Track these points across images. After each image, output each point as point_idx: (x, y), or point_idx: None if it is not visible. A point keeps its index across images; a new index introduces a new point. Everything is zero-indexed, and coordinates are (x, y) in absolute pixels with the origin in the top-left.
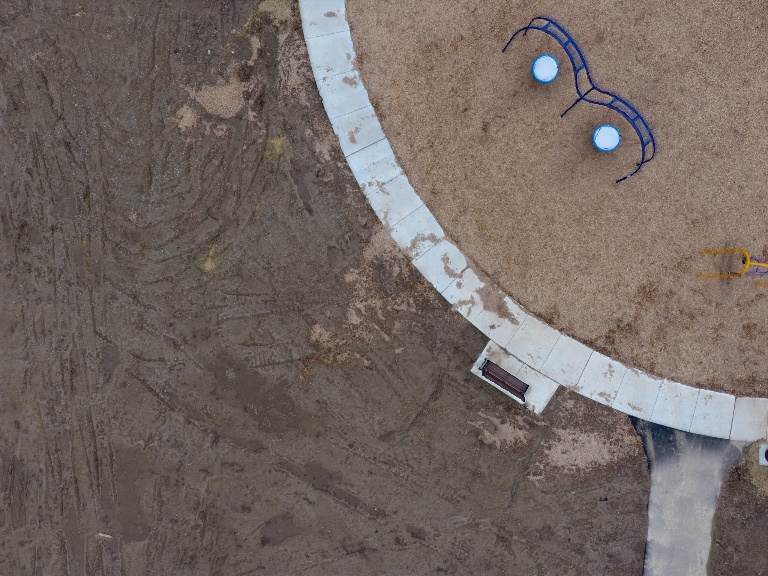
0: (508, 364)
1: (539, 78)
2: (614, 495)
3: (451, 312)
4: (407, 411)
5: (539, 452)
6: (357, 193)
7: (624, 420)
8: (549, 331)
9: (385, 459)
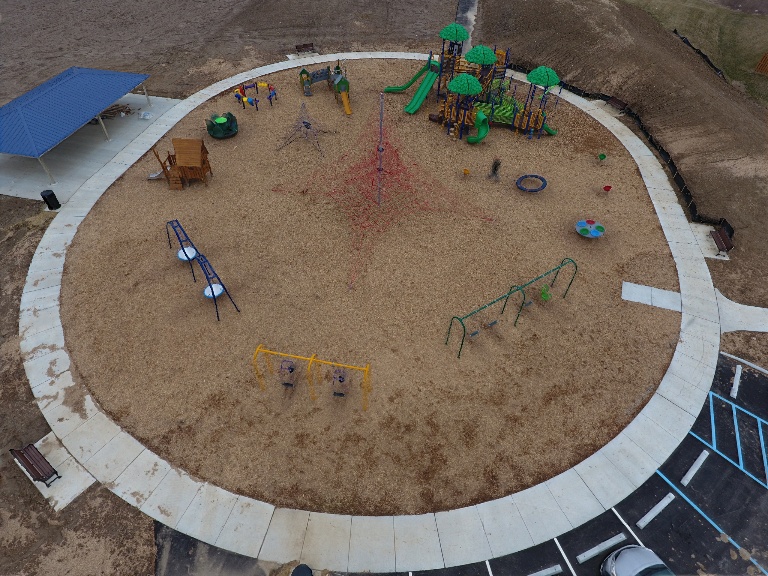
0: (55, 455)
1: (181, 257)
2: None
3: (30, 404)
4: None
5: (32, 557)
6: (14, 315)
7: (147, 525)
8: (112, 427)
9: None
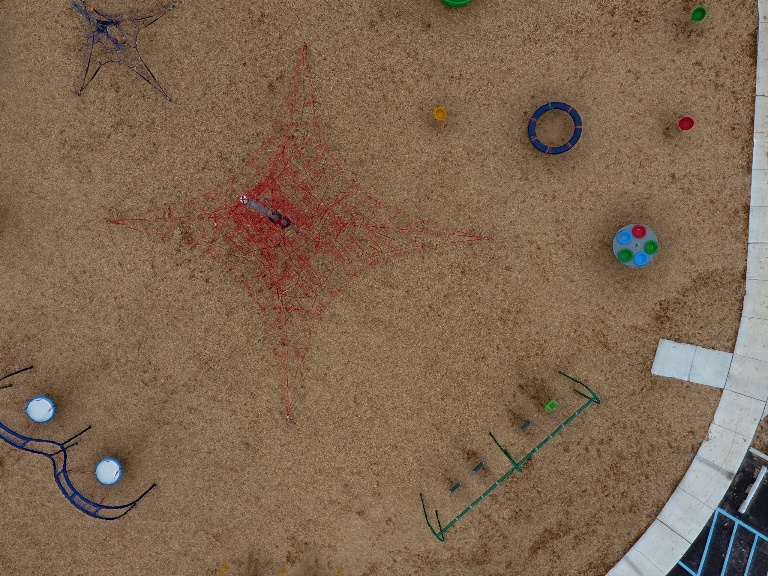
0: None
1: (35, 419)
2: None
3: None
4: None
5: None
6: None
7: None
8: None
9: None
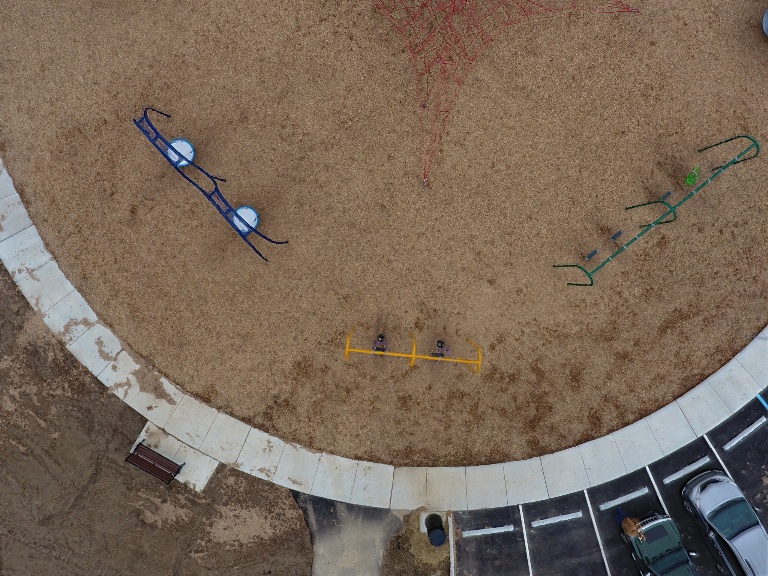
0: (167, 444)
1: None
2: (277, 568)
3: (107, 395)
4: (66, 495)
5: (200, 529)
6: (7, 281)
7: (285, 494)
8: (206, 410)
9: (45, 543)
